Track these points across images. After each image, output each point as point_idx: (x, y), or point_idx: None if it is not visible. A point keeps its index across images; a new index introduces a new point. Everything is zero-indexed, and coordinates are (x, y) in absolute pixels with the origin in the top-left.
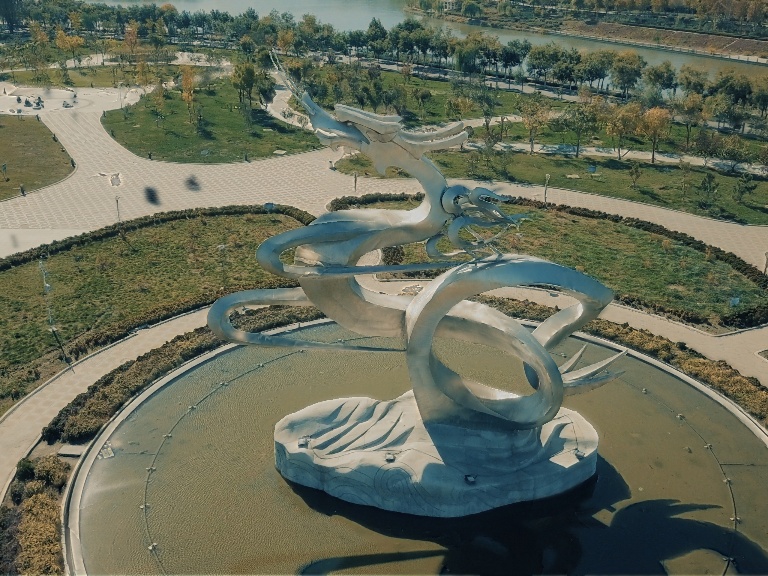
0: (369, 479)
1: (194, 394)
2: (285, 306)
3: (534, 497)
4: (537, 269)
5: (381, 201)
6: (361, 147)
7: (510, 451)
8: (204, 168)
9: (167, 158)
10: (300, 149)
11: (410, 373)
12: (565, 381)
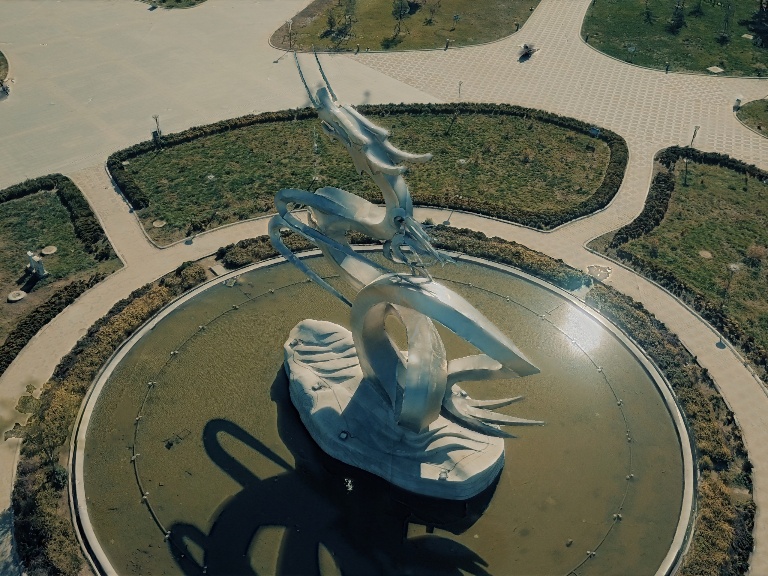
0: (297, 392)
1: (325, 271)
2: (469, 234)
3: (392, 481)
4: (439, 308)
5: (720, 165)
6: (347, 146)
7: (400, 437)
8: (616, 66)
9: (602, 44)
10: (742, 72)
11: (353, 336)
12: (464, 413)
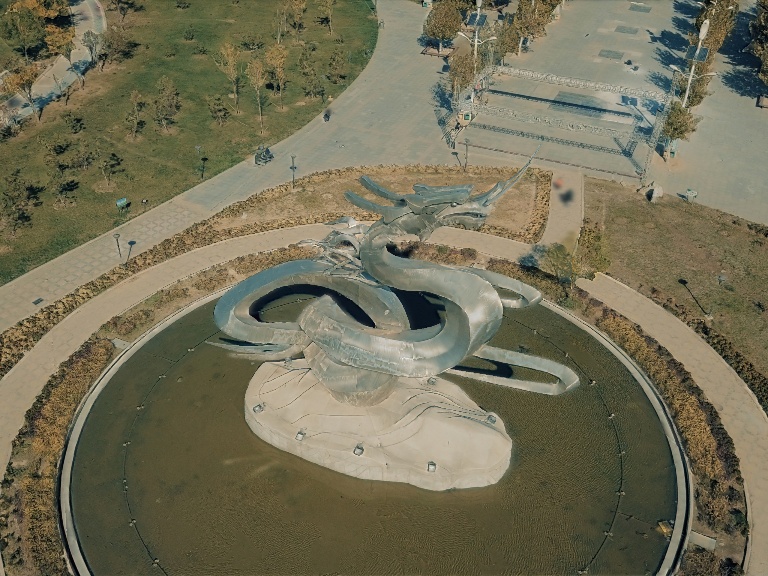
0: None
1: None
2: None
3: None
4: None
5: None
6: None
7: None
8: None
9: None
10: None
11: None
12: (279, 344)
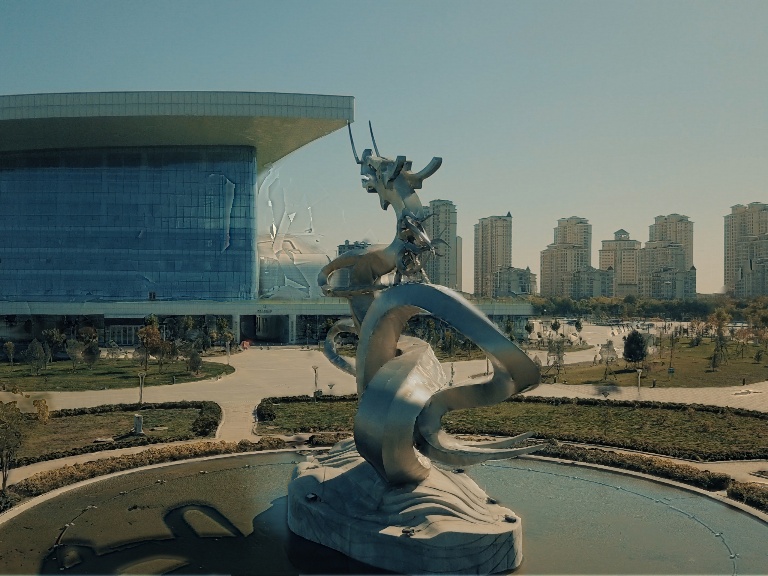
0: None
1: None
2: None
3: (350, 553)
4: (419, 291)
5: None
6: None
7: (377, 504)
8: None
9: None
10: None
11: None
12: (448, 447)
